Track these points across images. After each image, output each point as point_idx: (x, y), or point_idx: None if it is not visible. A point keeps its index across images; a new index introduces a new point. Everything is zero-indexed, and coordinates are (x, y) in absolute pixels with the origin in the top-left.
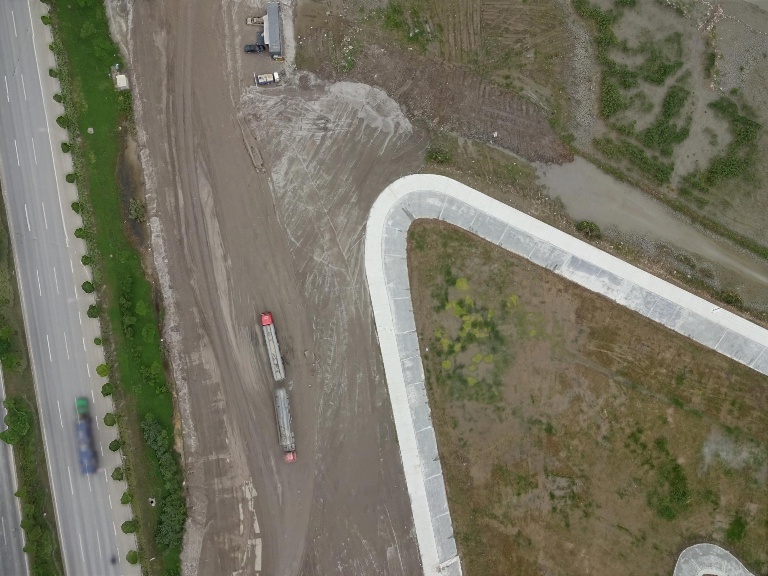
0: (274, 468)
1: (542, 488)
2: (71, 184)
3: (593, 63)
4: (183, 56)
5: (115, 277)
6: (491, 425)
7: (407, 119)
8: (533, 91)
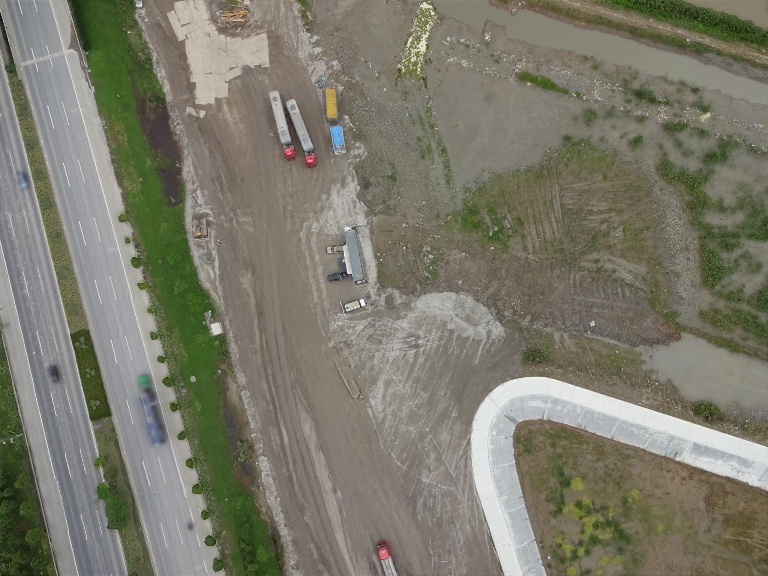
0: None
1: None
2: None
3: (688, 230)
4: (270, 294)
5: (232, 520)
6: None
7: (498, 322)
8: (627, 271)
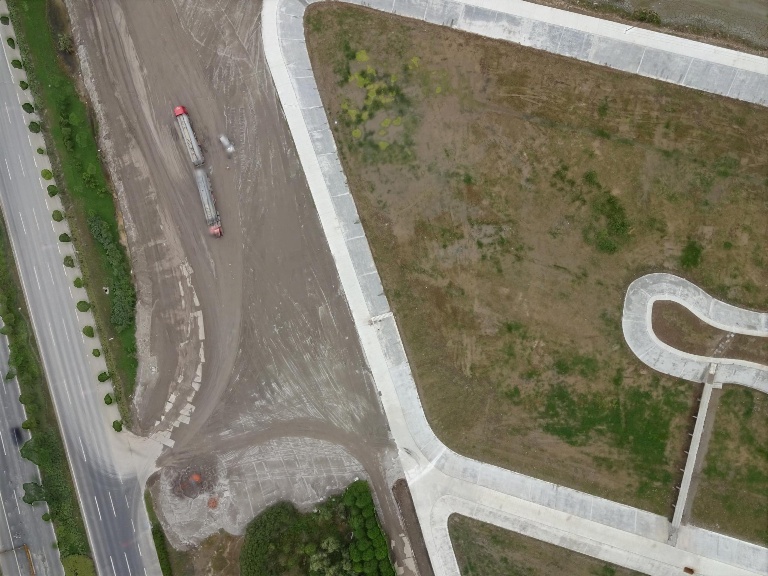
0: (205, 246)
1: (468, 238)
2: (10, 31)
3: None
4: None
5: (54, 103)
6: (408, 184)
7: None
8: None
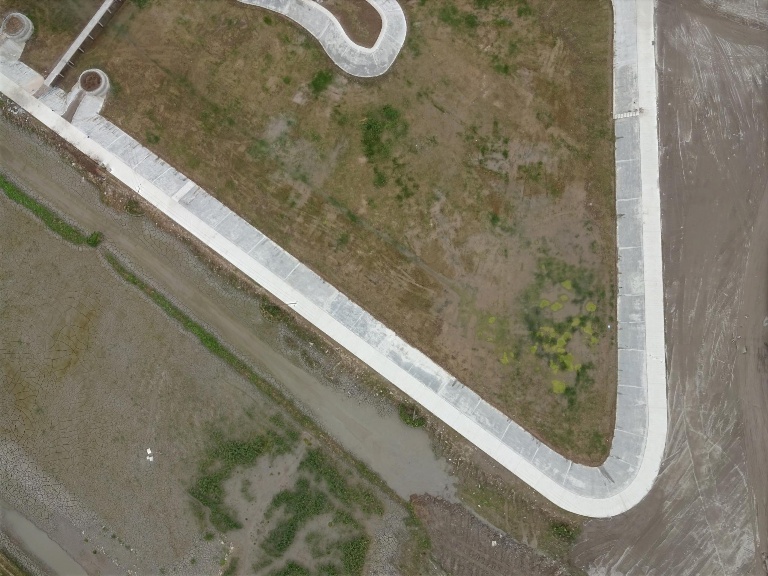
0: None
1: (514, 164)
2: None
3: None
4: None
5: None
6: (555, 237)
7: None
8: None
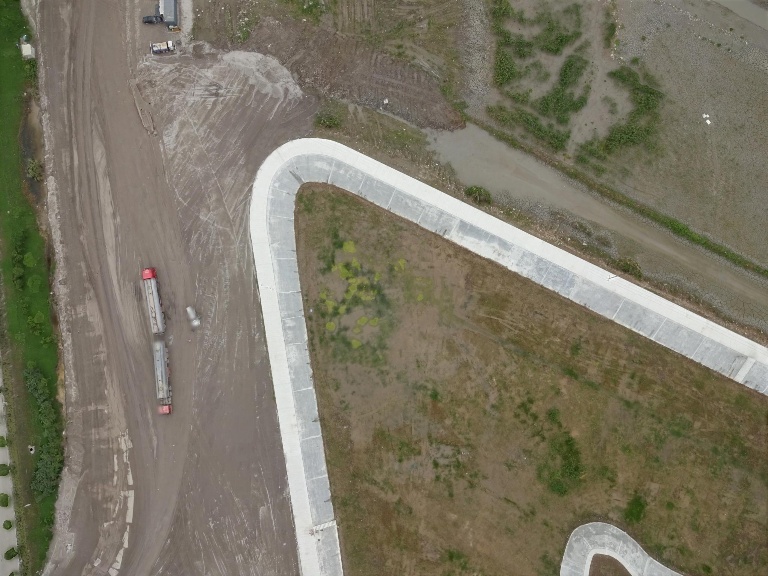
0: (150, 421)
1: (425, 455)
2: None
3: (488, 33)
4: (86, 27)
5: (11, 232)
6: (374, 389)
7: (298, 86)
8: (425, 60)
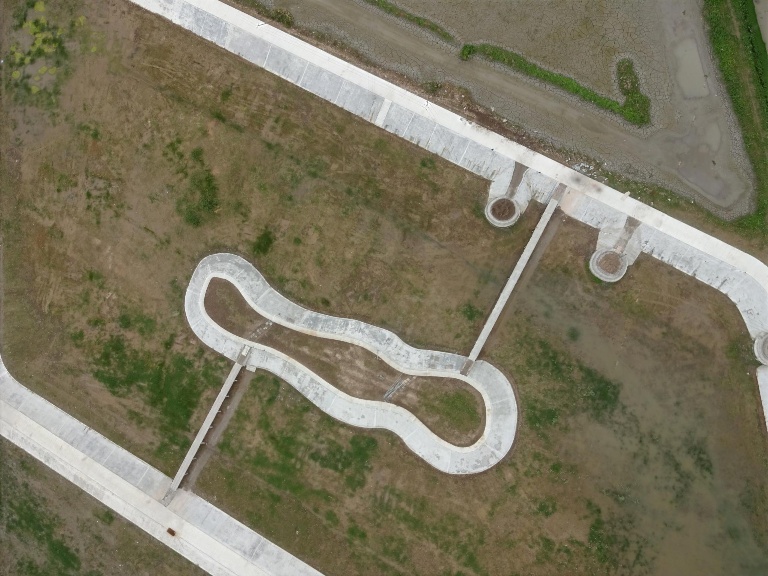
0: None
1: (81, 187)
2: None
3: None
4: None
5: None
6: (45, 128)
7: None
8: None
